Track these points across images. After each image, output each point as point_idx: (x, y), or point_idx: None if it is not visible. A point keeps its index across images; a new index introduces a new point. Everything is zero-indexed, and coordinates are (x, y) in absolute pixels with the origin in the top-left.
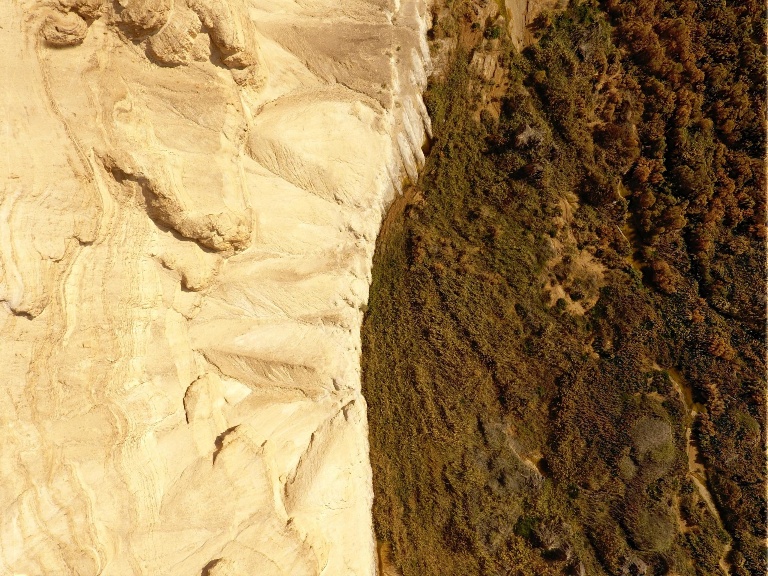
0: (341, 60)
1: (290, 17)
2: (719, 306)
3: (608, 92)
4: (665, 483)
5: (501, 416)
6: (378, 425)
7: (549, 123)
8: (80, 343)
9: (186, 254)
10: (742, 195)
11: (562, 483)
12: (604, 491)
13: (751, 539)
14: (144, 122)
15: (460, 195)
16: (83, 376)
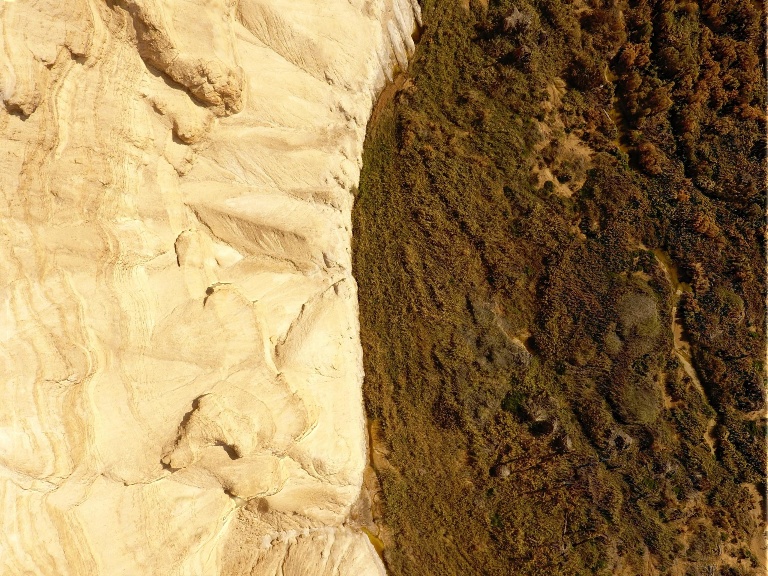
0: None
1: None
2: (704, 185)
3: None
4: (650, 358)
5: (489, 295)
6: (368, 305)
7: (537, 9)
8: (72, 159)
9: (177, 101)
10: (727, 76)
11: (549, 360)
12: (590, 366)
13: (735, 413)
14: None
15: (449, 80)
16: (75, 191)
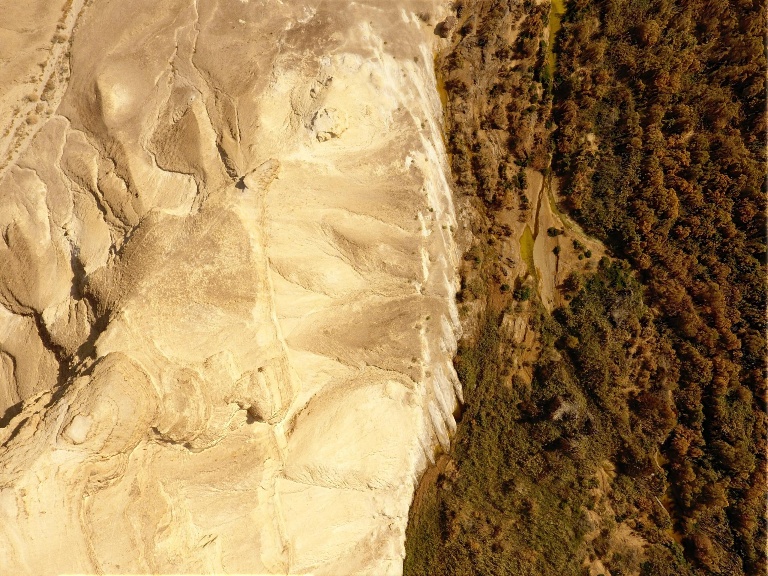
0: (372, 348)
1: (320, 315)
2: None
3: (642, 356)
4: None
5: None
6: None
7: (583, 390)
8: None
9: None
10: None
11: None
12: None
13: None
14: (184, 521)
15: (494, 467)
16: None
